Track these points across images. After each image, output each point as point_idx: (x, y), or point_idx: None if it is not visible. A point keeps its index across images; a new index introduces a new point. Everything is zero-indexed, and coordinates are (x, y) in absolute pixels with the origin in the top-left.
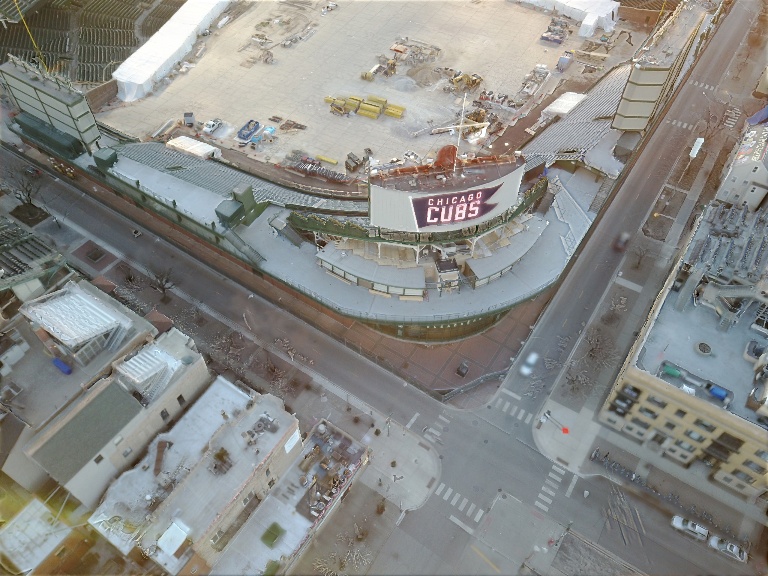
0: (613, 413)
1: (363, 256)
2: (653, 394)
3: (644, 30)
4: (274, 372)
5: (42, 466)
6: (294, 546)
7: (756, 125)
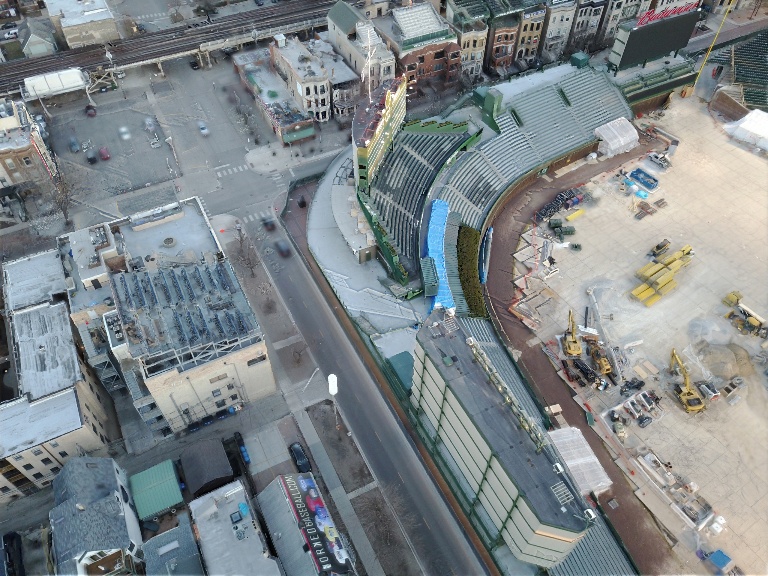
0: None
1: None
2: None
3: None
4: None
5: (335, 4)
6: None
7: None
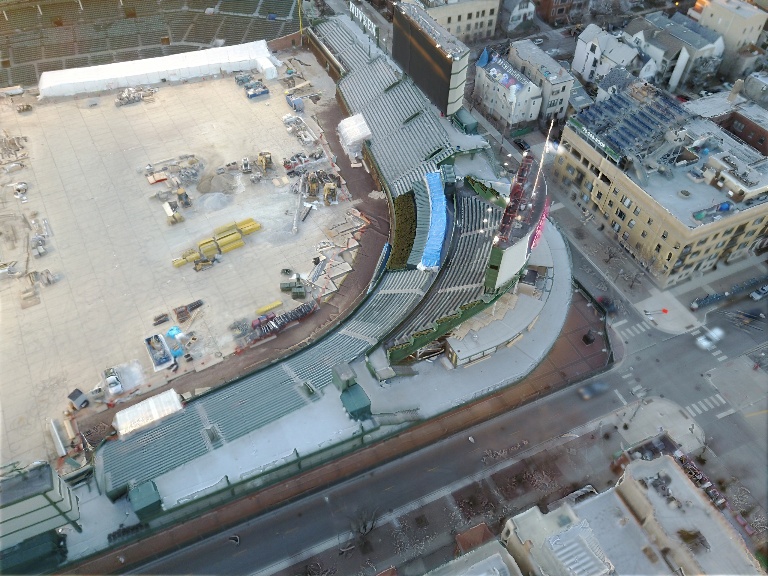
0: (670, 276)
1: (484, 325)
2: (701, 238)
3: (299, 51)
4: (524, 479)
5: None
6: (744, 534)
7: (488, 65)
